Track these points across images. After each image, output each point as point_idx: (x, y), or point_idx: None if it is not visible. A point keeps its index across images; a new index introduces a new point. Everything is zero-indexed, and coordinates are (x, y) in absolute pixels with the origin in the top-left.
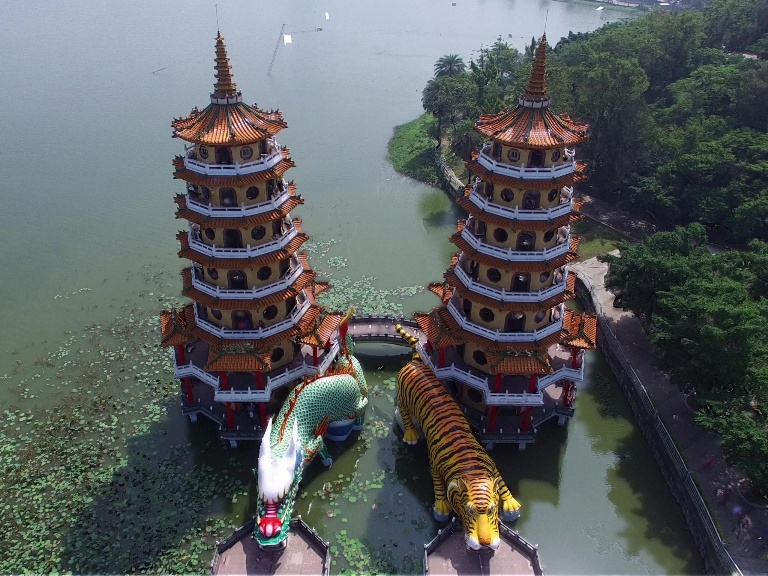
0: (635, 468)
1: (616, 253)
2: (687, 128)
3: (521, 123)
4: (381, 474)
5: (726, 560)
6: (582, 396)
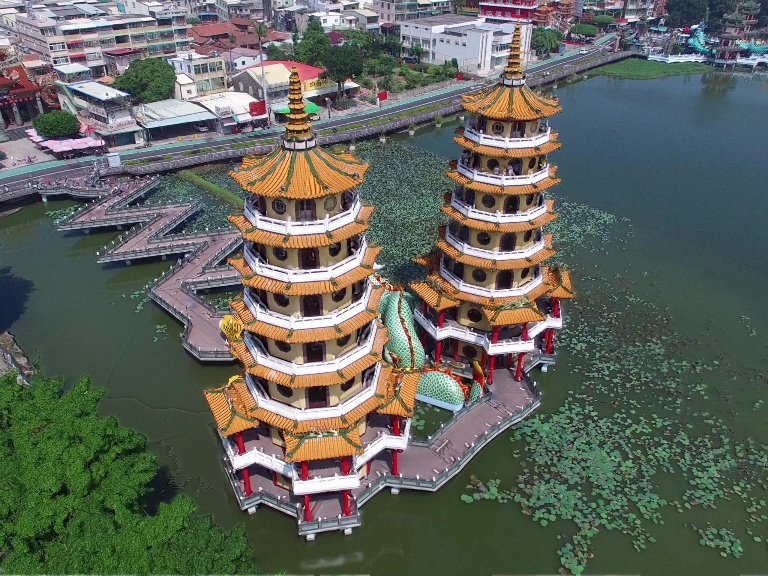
0: None
1: None
2: None
3: None
4: None
5: None
6: None
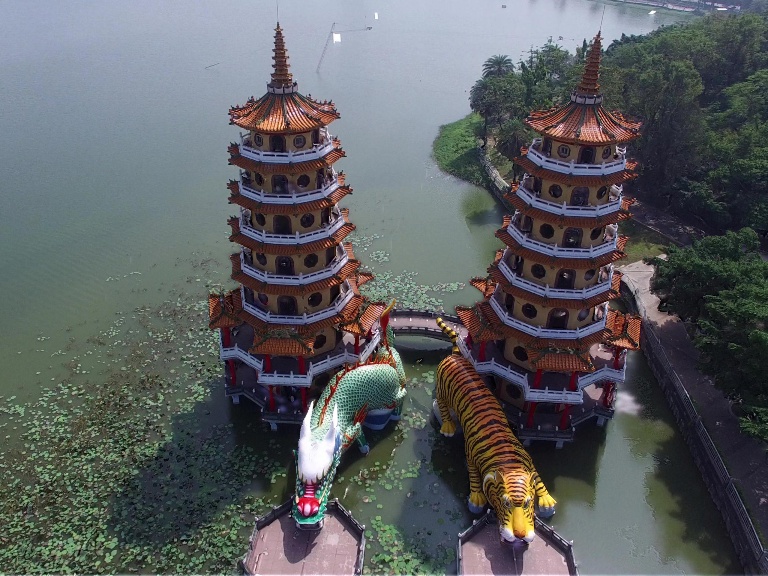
0: (675, 473)
1: (662, 258)
2: (742, 133)
3: (573, 119)
4: (417, 464)
5: (767, 569)
6: (622, 398)
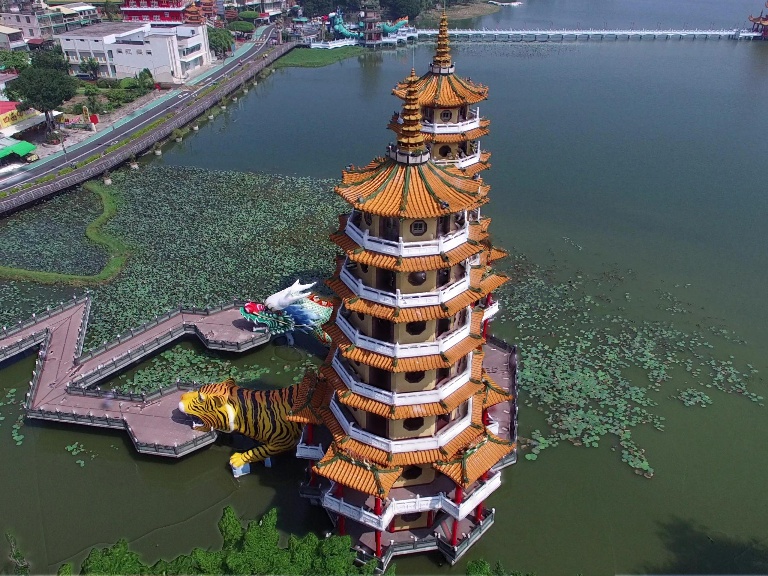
0: None
1: None
2: None
3: None
4: None
5: None
6: None
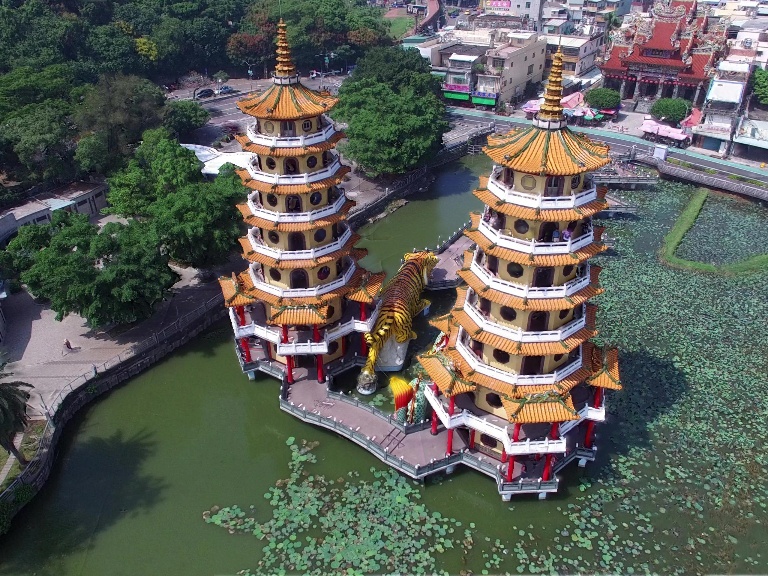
0: None
1: None
2: None
3: None
4: None
5: None
6: None
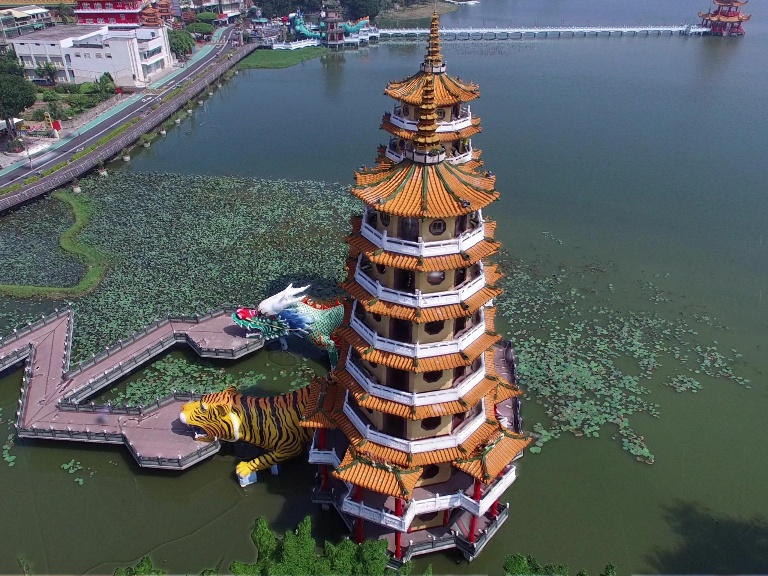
0: None
1: None
2: None
3: None
4: None
5: None
6: None
